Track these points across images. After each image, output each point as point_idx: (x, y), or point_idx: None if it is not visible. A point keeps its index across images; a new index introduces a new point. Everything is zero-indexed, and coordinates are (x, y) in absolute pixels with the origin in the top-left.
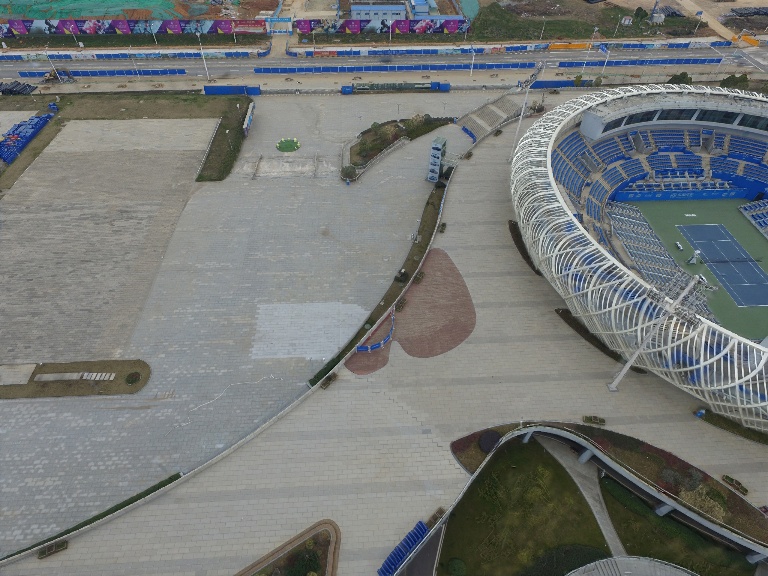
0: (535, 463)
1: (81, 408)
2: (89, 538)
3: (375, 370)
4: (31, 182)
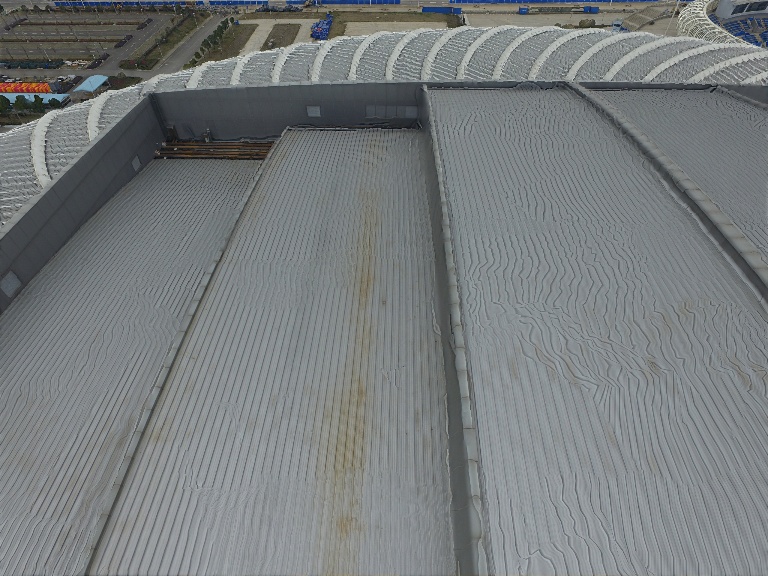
0: None
1: None
2: None
3: None
4: None
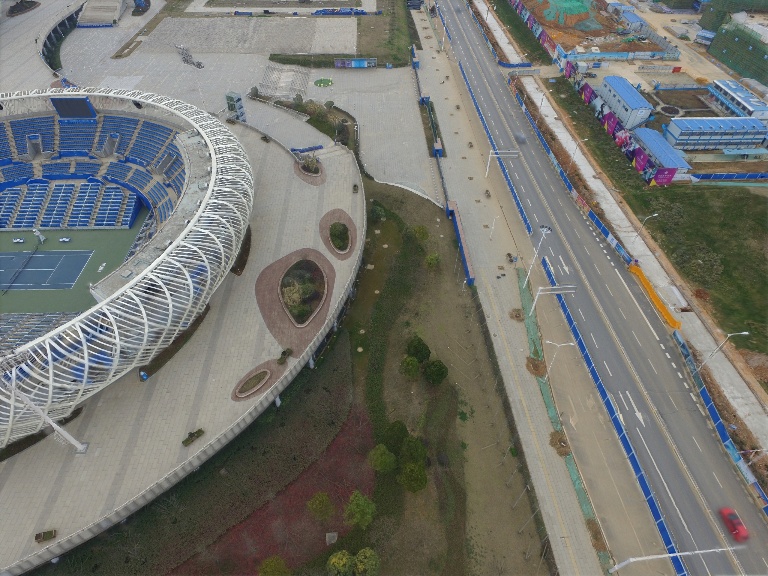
0: None
1: None
2: None
3: (51, 85)
4: None
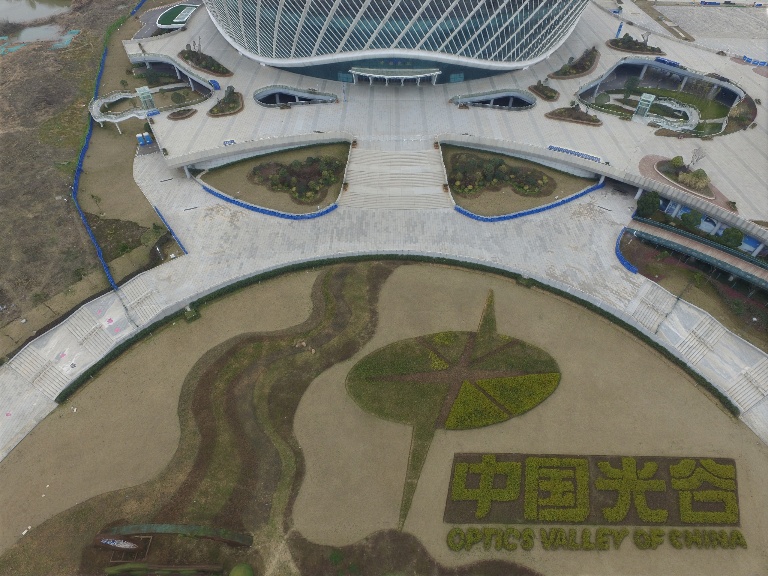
0: (721, 110)
1: (668, 34)
2: (636, 27)
3: (736, 62)
4: (767, 10)
